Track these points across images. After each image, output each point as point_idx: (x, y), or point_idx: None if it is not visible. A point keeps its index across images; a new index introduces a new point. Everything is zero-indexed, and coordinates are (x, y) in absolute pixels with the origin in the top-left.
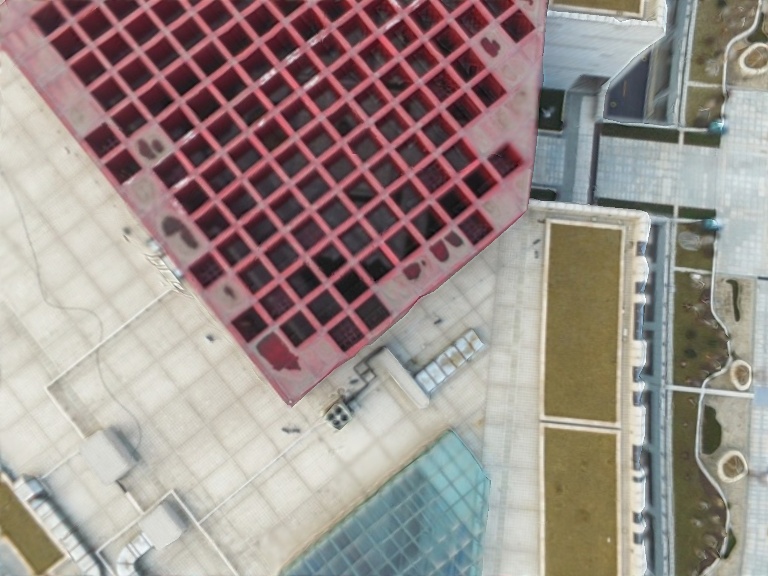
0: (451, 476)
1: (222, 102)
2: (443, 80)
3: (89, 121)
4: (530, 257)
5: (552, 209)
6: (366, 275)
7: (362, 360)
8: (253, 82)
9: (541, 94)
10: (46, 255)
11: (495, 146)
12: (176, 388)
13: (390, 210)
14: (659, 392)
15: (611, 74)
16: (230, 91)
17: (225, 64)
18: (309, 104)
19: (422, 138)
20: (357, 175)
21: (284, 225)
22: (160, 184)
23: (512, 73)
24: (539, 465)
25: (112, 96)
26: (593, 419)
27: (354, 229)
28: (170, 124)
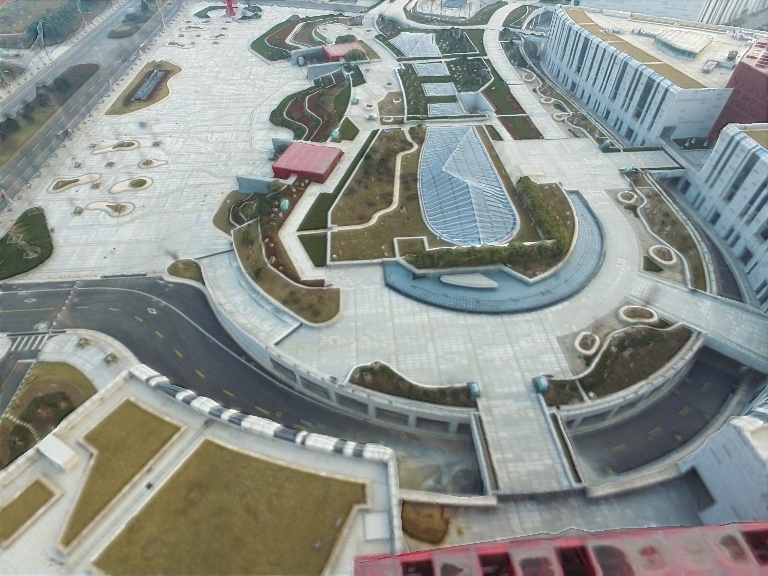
0: (689, 48)
1: None
2: None
3: None
4: None
5: None
6: None
7: (736, 65)
8: None
9: None
10: None
11: None
12: None
13: None
14: None
15: None
16: None
17: None
18: None
19: None
20: None
21: None
22: None
23: None
24: None
25: None
26: None
27: None
28: None
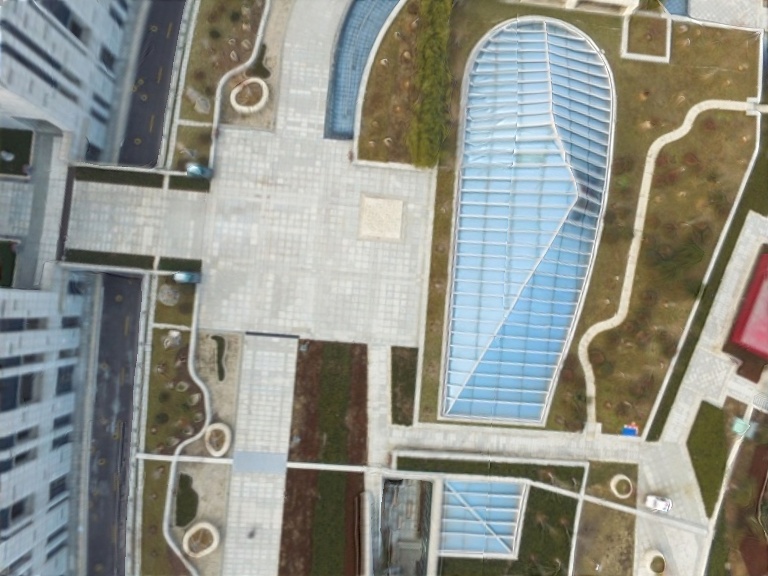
0: None
1: None
2: None
3: None
4: None
5: None
6: None
7: None
8: None
9: (0, 135)
10: None
11: None
12: None
13: None
14: (130, 461)
15: (39, 116)
16: None
17: None
18: None
19: None
20: None
21: None
22: None
23: None
24: None
25: None
26: None
27: None
28: None
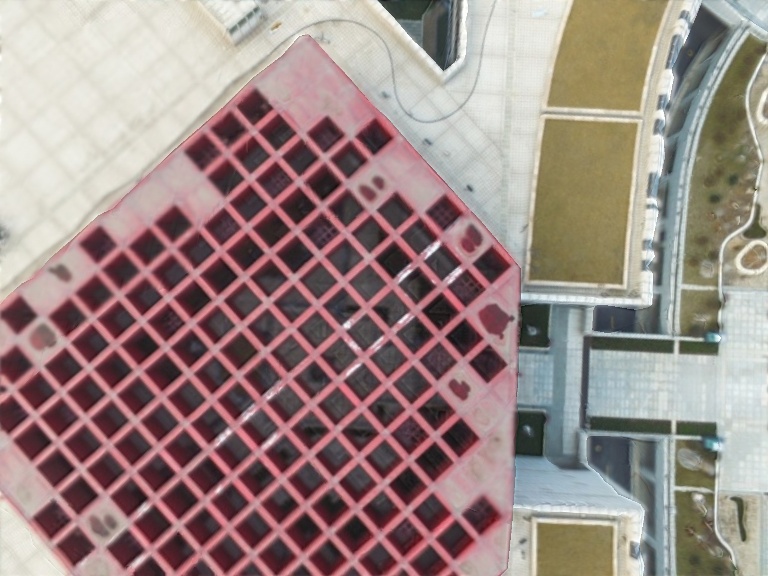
0: None
1: (175, 469)
2: (410, 428)
3: (37, 498)
4: (517, 557)
5: (537, 510)
6: None
7: None
8: (207, 443)
9: (525, 311)
10: None
11: (469, 499)
12: None
13: None
14: None
15: None
16: (183, 455)
17: (176, 426)
18: (268, 465)
19: (390, 496)
20: (323, 541)
21: None
22: (115, 563)
23: (484, 416)
24: None
25: (59, 469)
26: None
27: None
28: (122, 494)
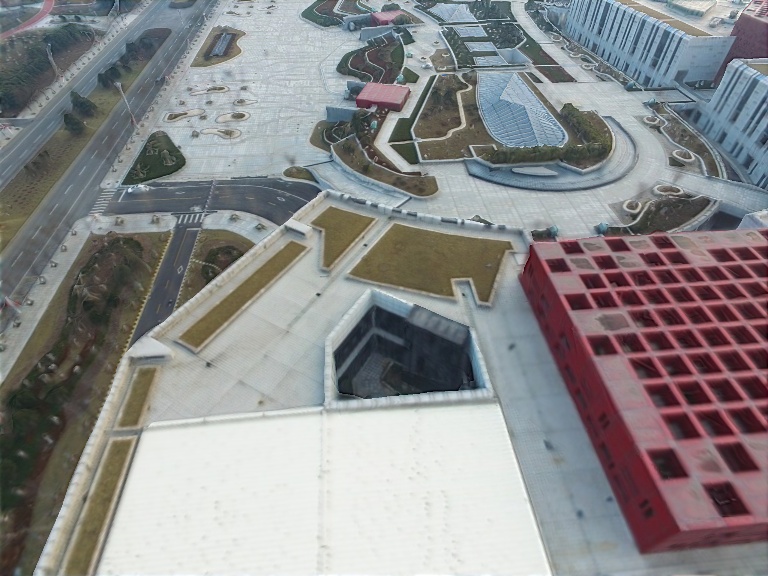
0: (697, 8)
1: None
2: None
3: None
4: None
5: None
6: None
7: None
8: None
9: None
10: None
11: None
12: None
13: None
14: None
15: None
16: None
17: None
18: None
19: None
20: None
21: None
22: None
23: None
24: (671, 16)
25: None
26: None
27: None
28: None
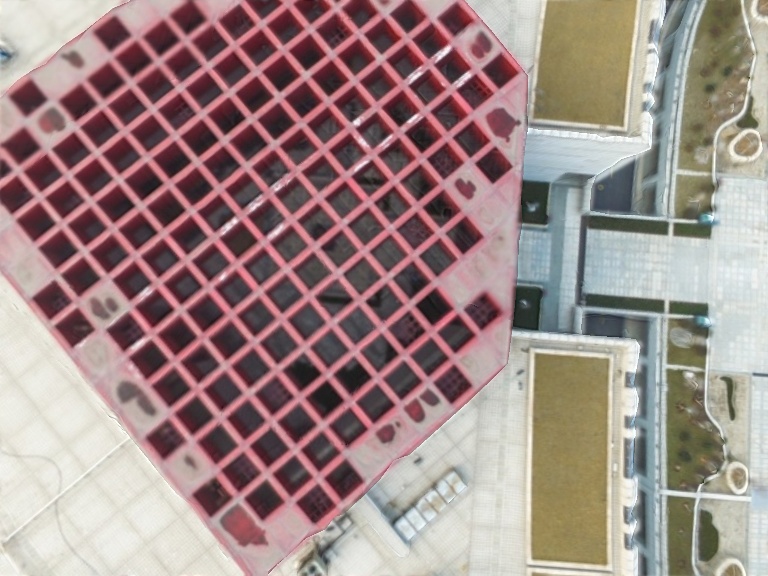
0: None
1: (180, 255)
2: (416, 225)
3: (37, 279)
4: (514, 388)
5: (536, 339)
6: (337, 439)
7: None
8: (213, 232)
9: (525, 187)
10: (0, 399)
11: (472, 295)
12: (141, 539)
13: (361, 368)
14: (653, 497)
15: (597, 172)
16: (189, 242)
17: (183, 213)
18: (273, 255)
19: (394, 289)
20: (326, 331)
21: (248, 387)
22: (114, 346)
23: (489, 216)
24: None
25: (62, 251)
26: (583, 562)
27: (323, 389)
28: (125, 279)
